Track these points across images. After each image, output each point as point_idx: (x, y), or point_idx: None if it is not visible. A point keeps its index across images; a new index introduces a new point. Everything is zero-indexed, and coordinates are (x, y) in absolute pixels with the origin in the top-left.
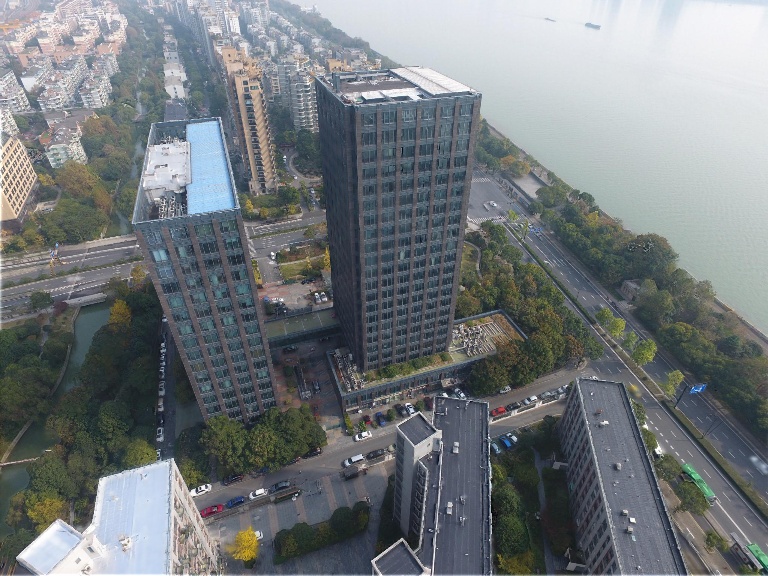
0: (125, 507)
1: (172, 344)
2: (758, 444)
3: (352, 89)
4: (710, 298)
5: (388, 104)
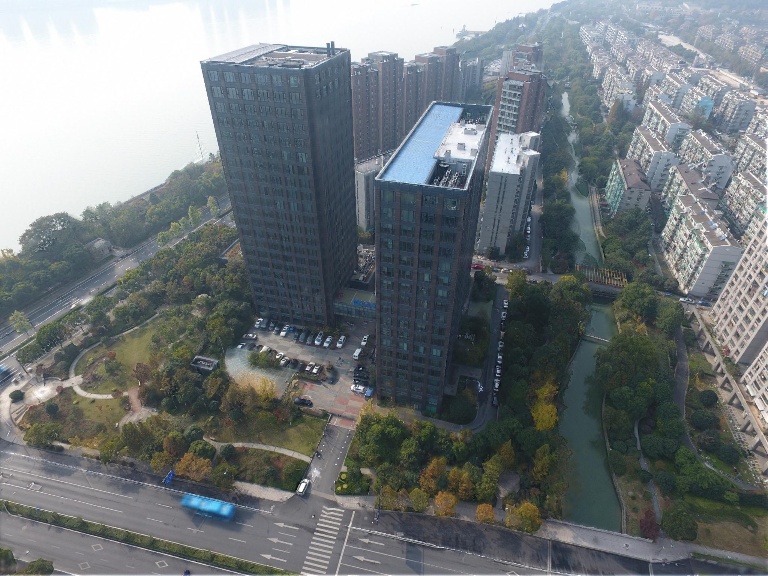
0: (509, 168)
1: (488, 389)
2: (218, 198)
3: (317, 56)
4: (110, 206)
5: (324, 48)
